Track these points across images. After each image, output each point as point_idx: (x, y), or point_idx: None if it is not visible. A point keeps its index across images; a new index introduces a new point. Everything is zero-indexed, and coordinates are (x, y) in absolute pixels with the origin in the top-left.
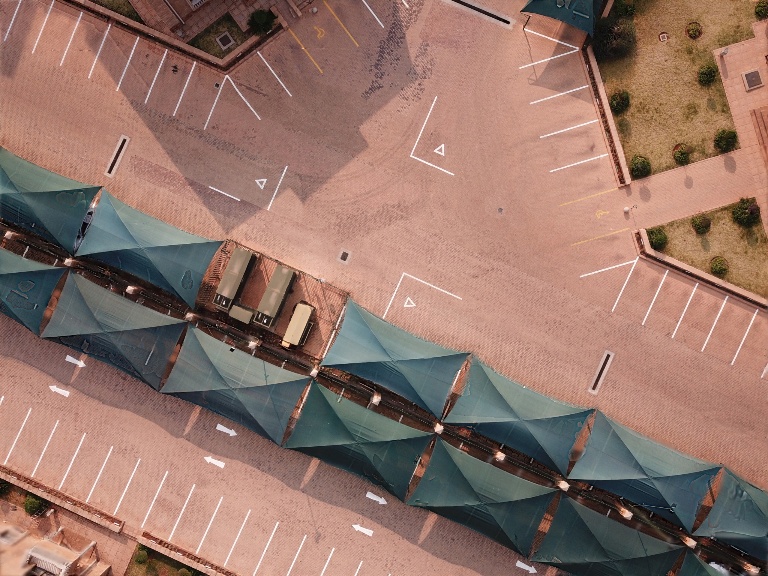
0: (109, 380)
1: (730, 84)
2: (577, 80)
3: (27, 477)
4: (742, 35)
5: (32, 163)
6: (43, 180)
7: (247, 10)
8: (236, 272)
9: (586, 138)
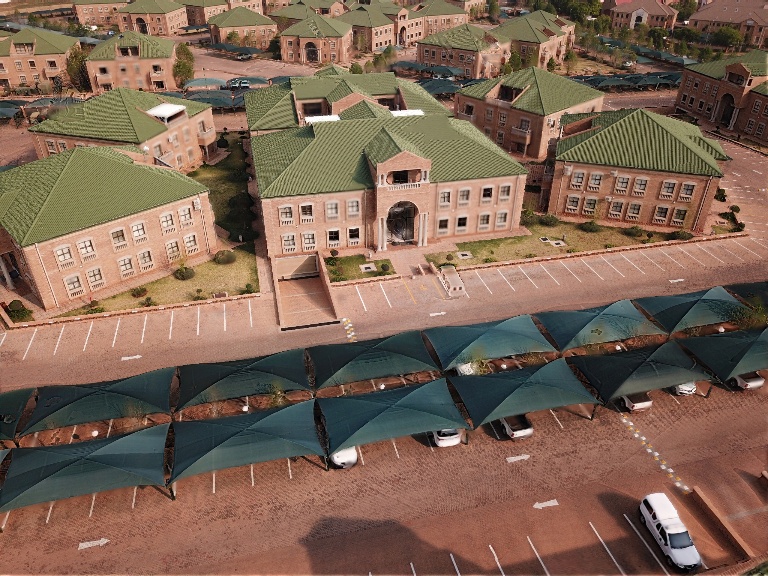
0: None
1: None
2: None
3: None
4: None
5: None
6: None
7: None
8: None
9: None
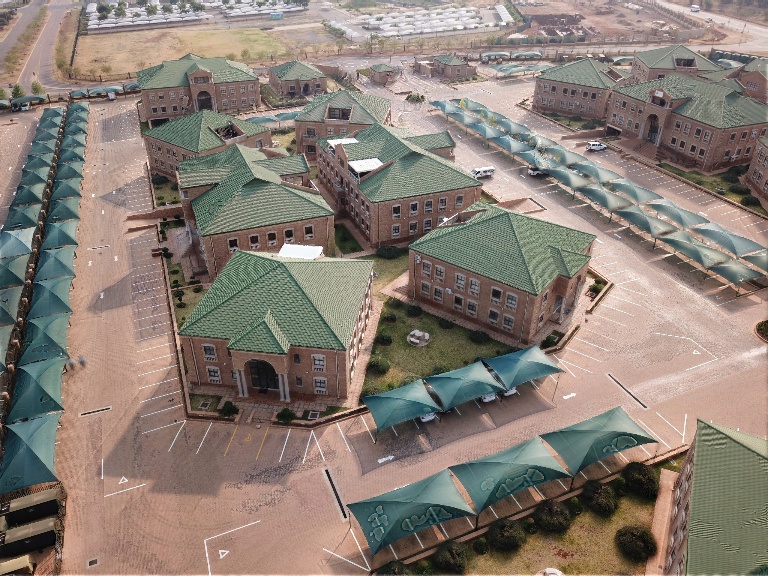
0: None
1: None
2: None
3: None
4: None
5: None
6: (52, 385)
7: None
8: (35, 499)
9: None
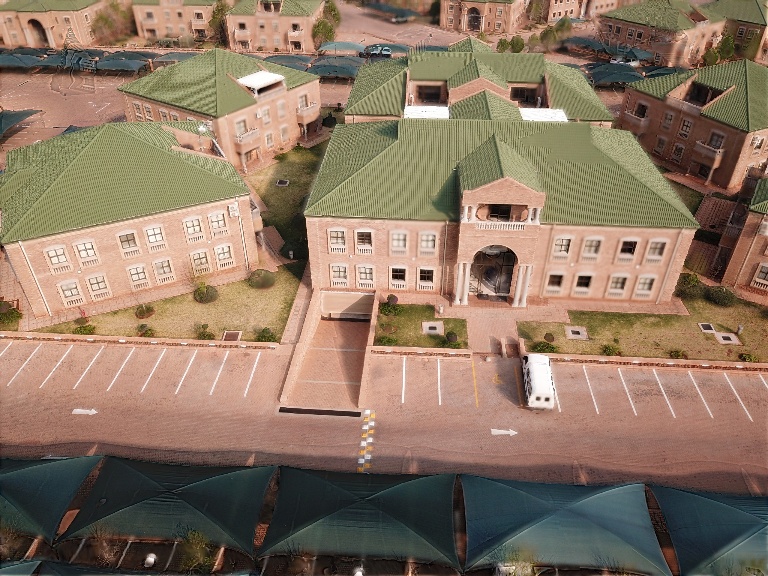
0: None
1: None
2: None
3: (266, 53)
4: None
5: None
6: None
7: None
8: None
9: None
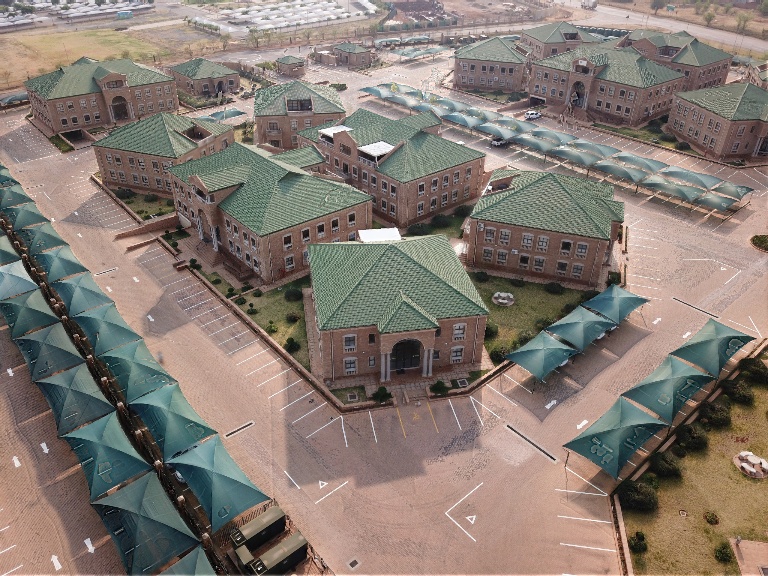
0: (98, 573)
1: (747, 570)
2: (602, 515)
3: None
4: (757, 537)
5: (189, 404)
6: (188, 412)
7: (376, 389)
8: (264, 521)
9: (602, 561)
